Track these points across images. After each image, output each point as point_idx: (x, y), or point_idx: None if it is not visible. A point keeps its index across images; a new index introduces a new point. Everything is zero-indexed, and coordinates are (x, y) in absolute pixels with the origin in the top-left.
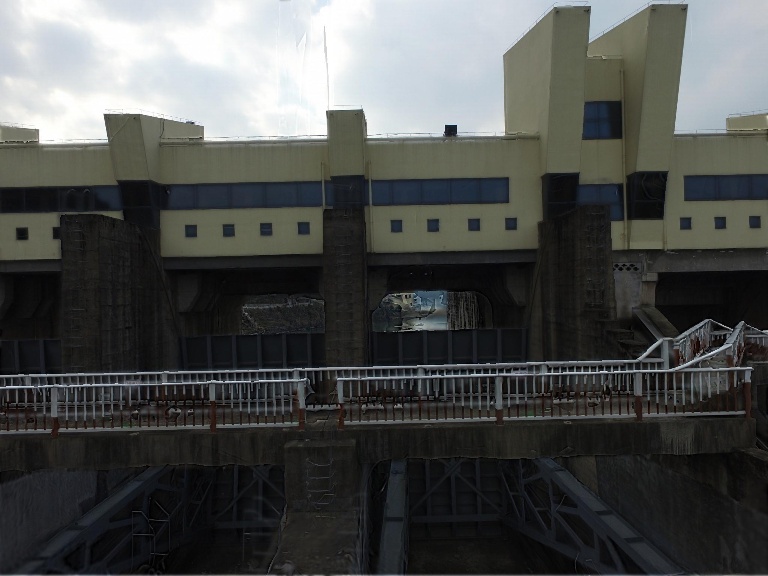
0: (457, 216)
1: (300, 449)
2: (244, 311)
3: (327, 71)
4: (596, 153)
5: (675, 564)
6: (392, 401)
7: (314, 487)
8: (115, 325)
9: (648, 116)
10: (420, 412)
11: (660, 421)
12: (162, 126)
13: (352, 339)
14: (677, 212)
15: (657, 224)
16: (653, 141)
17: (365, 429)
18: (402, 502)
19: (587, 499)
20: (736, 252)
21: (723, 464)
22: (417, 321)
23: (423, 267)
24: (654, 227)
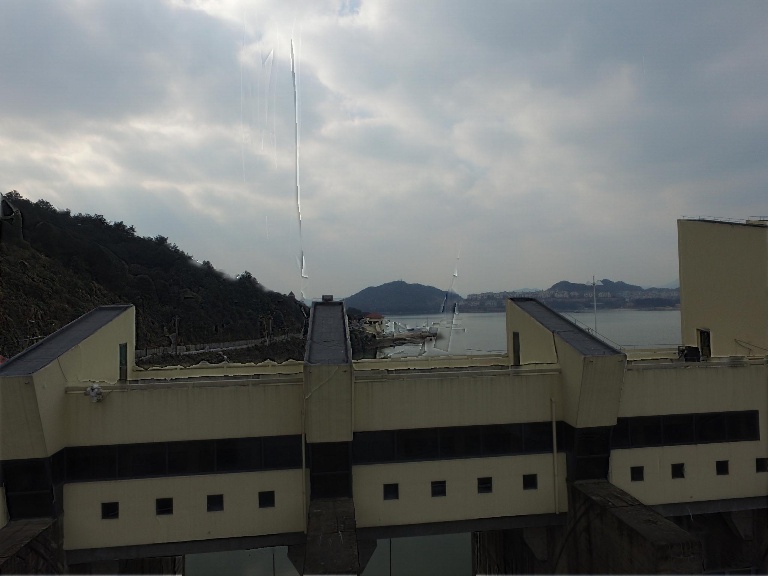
0: (703, 458)
1: None
2: (223, 354)
3: (294, 90)
4: None
5: None
6: None
7: None
8: None
9: None
10: None
11: None
12: None
13: None
14: None
15: None
16: None
17: None
18: None
19: None
20: None
21: None
22: (391, 350)
23: None
24: None
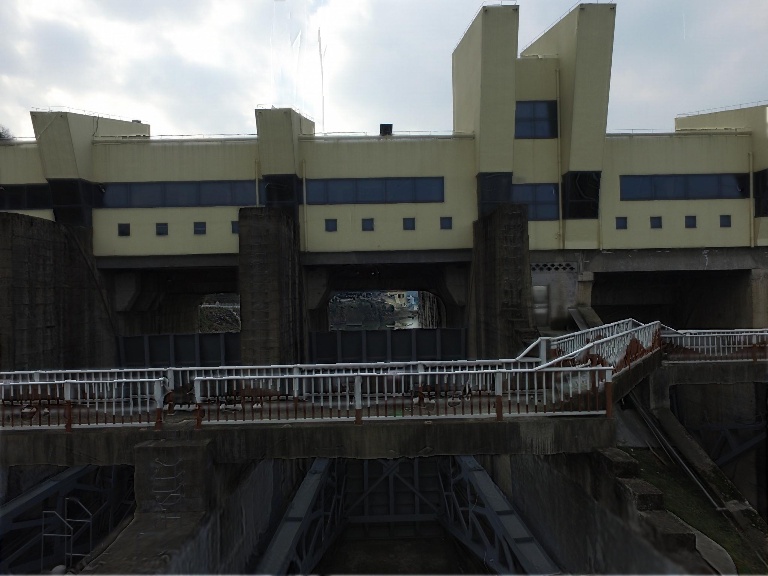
0: (392, 215)
1: (149, 449)
2: (233, 310)
3: (322, 70)
4: (532, 152)
5: (555, 564)
6: (251, 401)
7: (159, 487)
8: (33, 324)
9: (580, 115)
10: (279, 412)
11: (520, 421)
12: (96, 124)
13: (267, 338)
14: (613, 212)
15: (591, 224)
16: (585, 140)
17: (222, 429)
18: (308, 502)
19: (494, 499)
20: (672, 252)
21: (587, 464)
22: (410, 321)
23: (368, 266)
24: (589, 227)
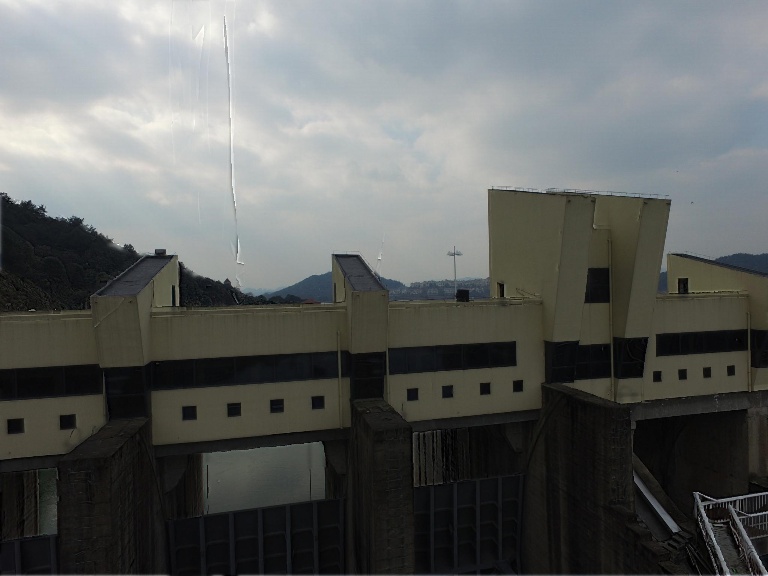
0: (470, 381)
1: None
2: None
3: (228, 69)
4: (589, 316)
5: None
6: None
7: None
8: (123, 574)
9: (636, 291)
10: None
11: None
12: (152, 291)
13: (403, 565)
14: (651, 366)
15: (638, 381)
16: (639, 312)
17: None
18: None
19: None
20: (693, 398)
21: None
22: None
23: None
24: (636, 384)
